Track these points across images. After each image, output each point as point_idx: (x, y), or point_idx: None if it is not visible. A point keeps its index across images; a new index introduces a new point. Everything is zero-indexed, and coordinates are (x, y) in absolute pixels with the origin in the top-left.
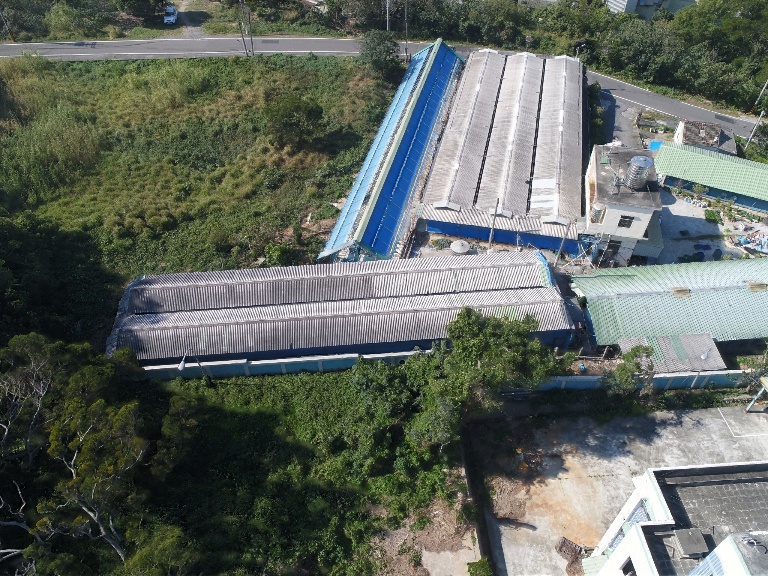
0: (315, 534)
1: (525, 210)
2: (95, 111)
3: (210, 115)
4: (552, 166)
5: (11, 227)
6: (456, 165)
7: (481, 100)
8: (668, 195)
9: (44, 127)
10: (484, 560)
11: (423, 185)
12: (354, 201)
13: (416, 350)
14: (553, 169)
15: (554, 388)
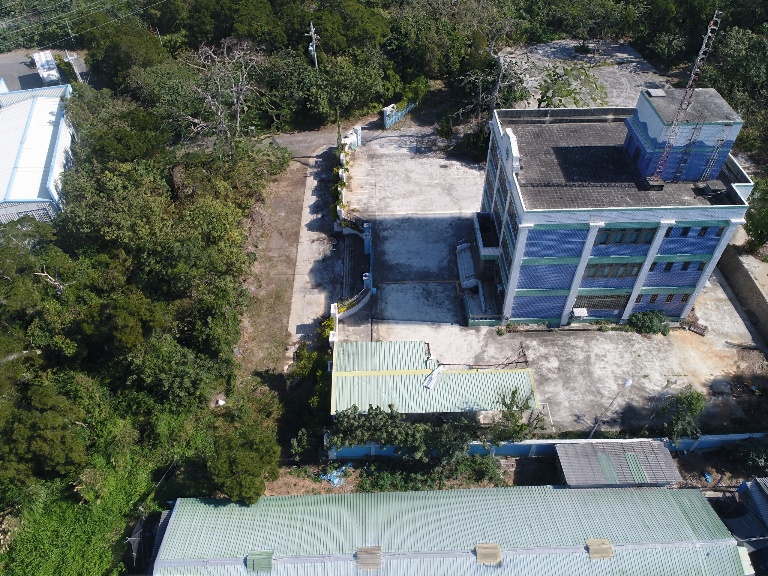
0: None
1: None
2: None
3: None
4: None
5: None
6: None
7: None
8: None
9: None
10: None
11: None
12: None
13: None
14: None
15: None
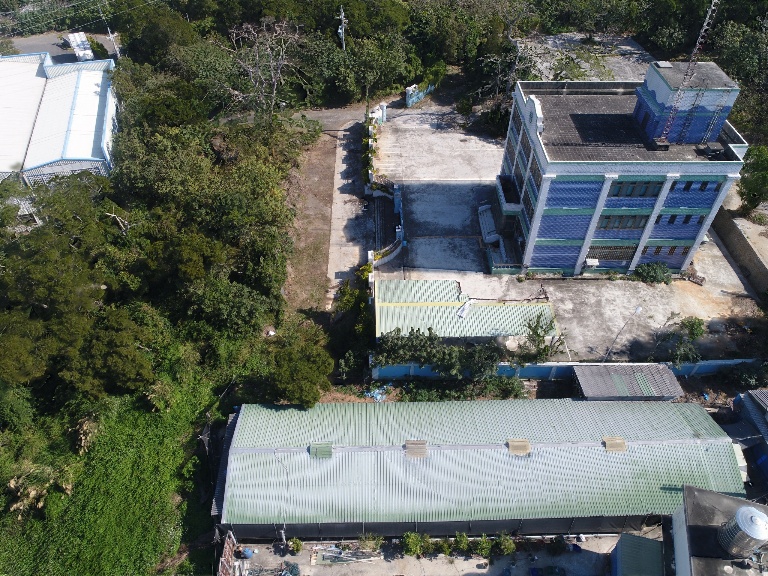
0: None
1: None
2: None
3: None
4: None
5: None
6: None
7: None
8: None
9: None
10: None
11: None
12: None
13: None
14: None
15: None
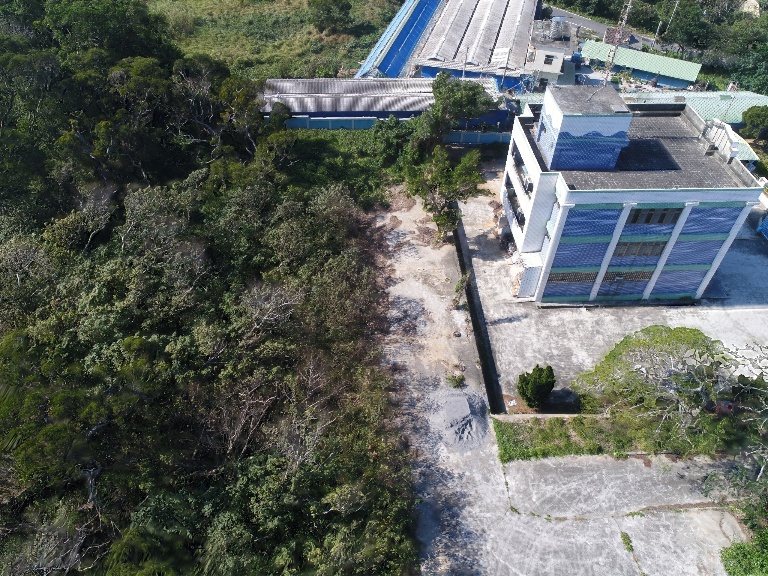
0: (353, 178)
1: (487, 62)
2: (186, 6)
3: (269, 11)
4: (508, 42)
5: (160, 40)
6: (443, 39)
7: (463, 8)
8: (589, 69)
9: (157, 7)
10: (443, 150)
11: (420, 52)
12: (373, 54)
13: (412, 117)
14: (509, 43)
15: (495, 141)
